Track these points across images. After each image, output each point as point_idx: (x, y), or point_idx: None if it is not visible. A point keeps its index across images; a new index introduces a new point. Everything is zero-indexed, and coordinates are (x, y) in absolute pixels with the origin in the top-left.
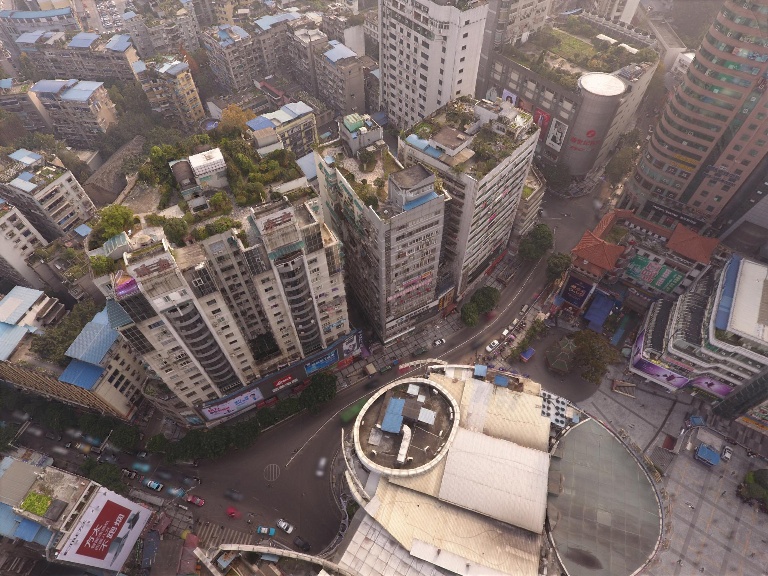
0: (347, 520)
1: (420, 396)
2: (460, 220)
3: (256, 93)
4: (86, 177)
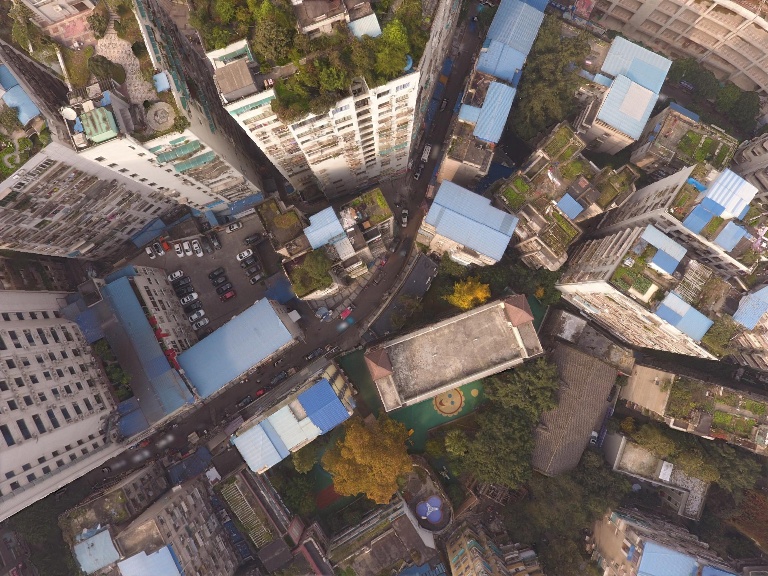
0: None
1: None
2: (42, 71)
3: (349, 573)
4: (624, 424)
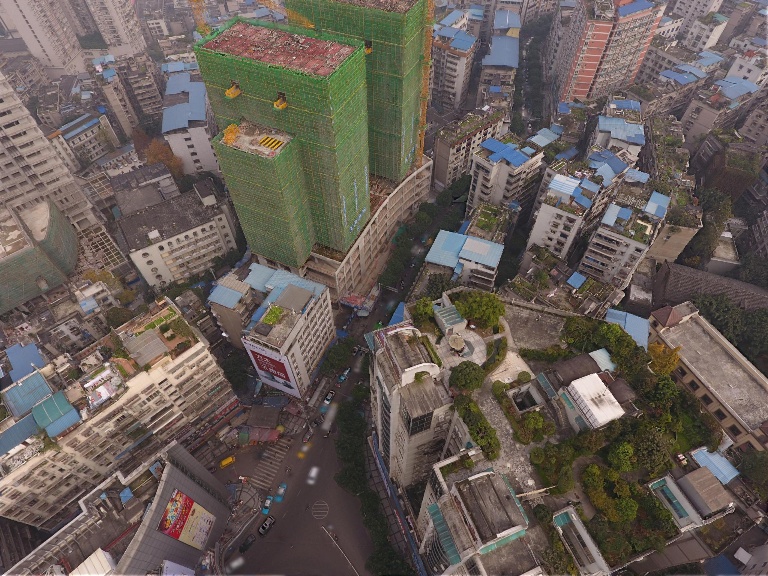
0: None
1: None
2: None
3: None
4: (694, 262)
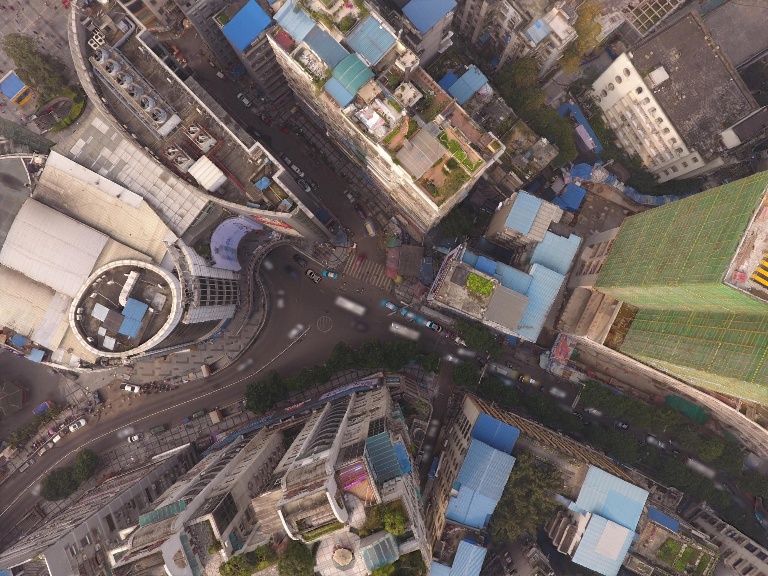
0: (211, 243)
1: (103, 334)
2: None
3: None
4: None
